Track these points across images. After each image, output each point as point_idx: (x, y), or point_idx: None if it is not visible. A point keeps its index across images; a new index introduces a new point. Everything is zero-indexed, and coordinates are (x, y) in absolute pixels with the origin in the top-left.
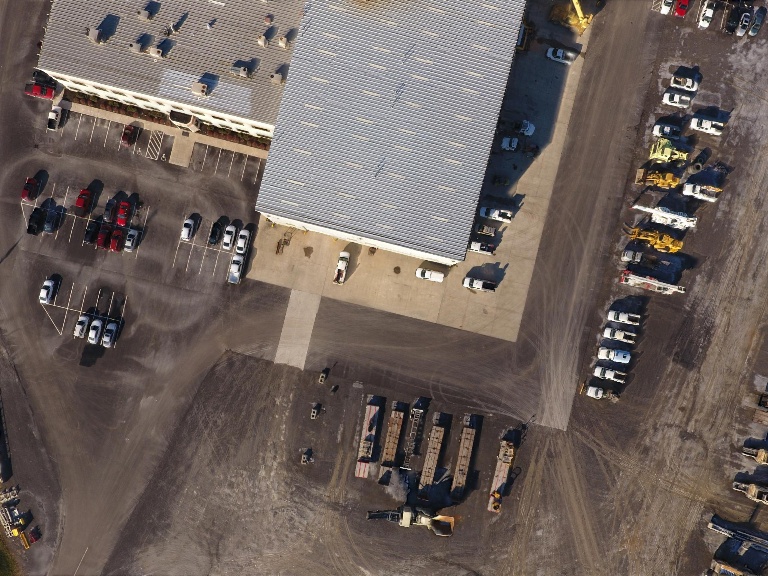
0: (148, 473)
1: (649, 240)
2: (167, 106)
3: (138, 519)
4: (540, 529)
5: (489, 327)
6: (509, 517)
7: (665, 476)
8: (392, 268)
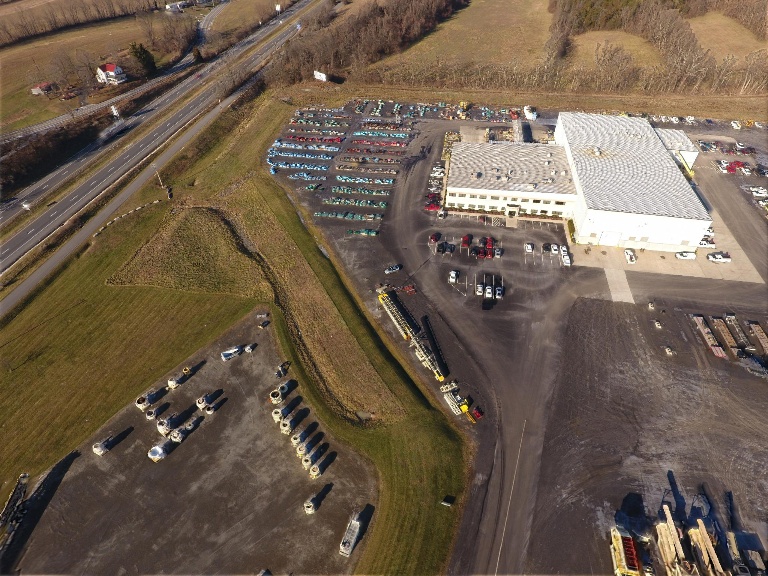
0: (554, 366)
1: None
2: (508, 200)
3: (559, 398)
4: None
5: (741, 278)
6: None
7: None
8: (659, 257)
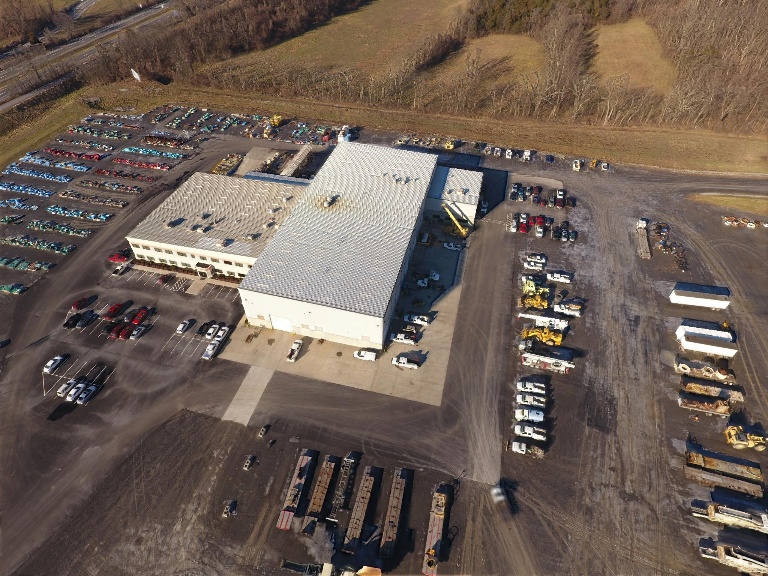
0: (56, 524)
1: (536, 334)
2: (197, 258)
3: None
4: None
5: (415, 394)
6: None
7: (620, 541)
8: (335, 353)
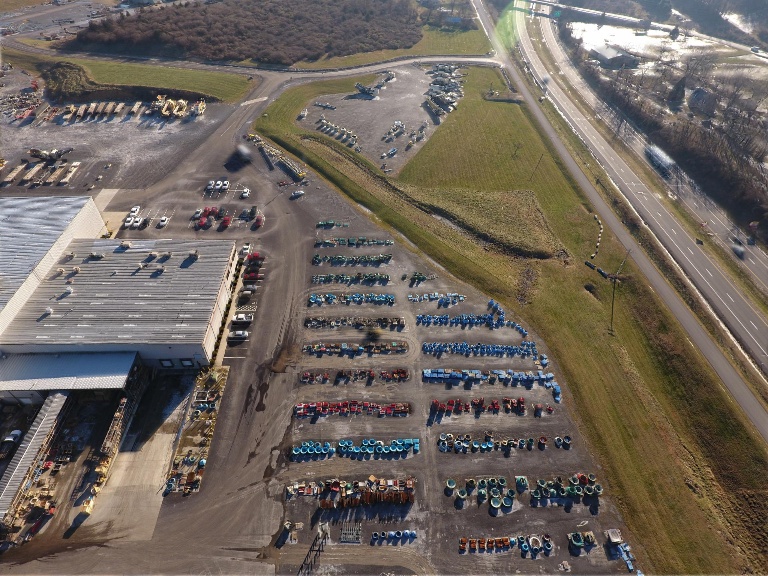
0: None
1: None
2: None
3: (198, 144)
4: None
5: None
6: None
7: None
8: None
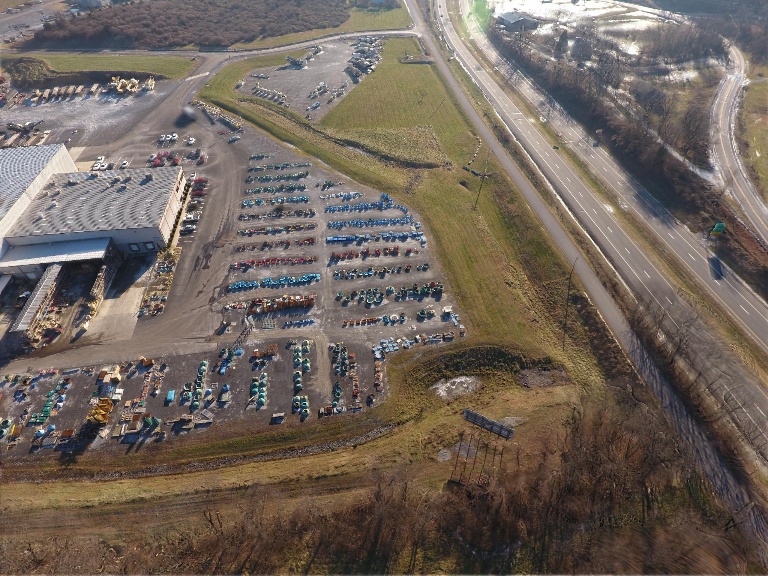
0: None
1: None
2: None
3: (150, 111)
4: None
5: None
6: None
7: None
8: None
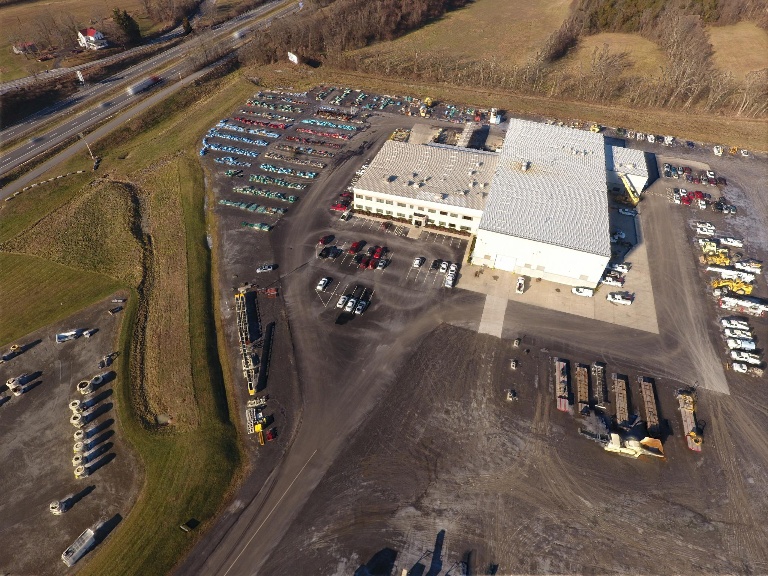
0: (378, 395)
1: (727, 284)
2: (415, 209)
3: (365, 431)
4: (750, 477)
5: (635, 324)
6: (713, 463)
7: None
8: (554, 289)
